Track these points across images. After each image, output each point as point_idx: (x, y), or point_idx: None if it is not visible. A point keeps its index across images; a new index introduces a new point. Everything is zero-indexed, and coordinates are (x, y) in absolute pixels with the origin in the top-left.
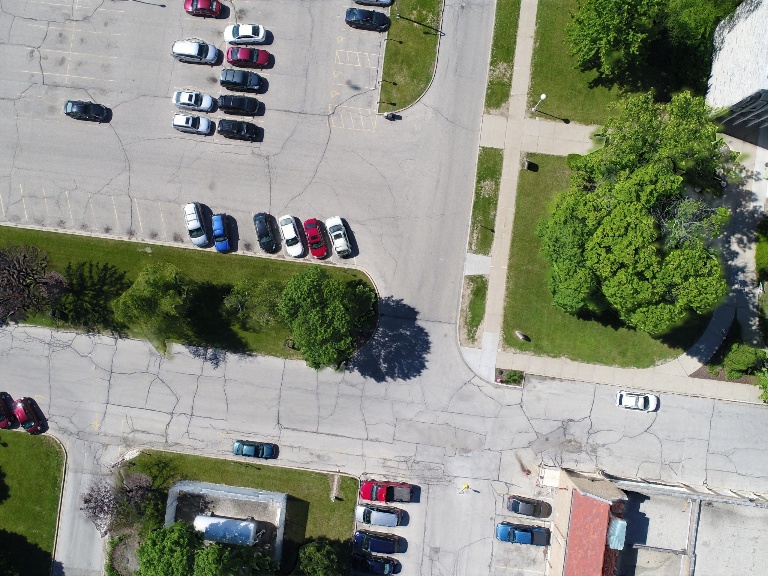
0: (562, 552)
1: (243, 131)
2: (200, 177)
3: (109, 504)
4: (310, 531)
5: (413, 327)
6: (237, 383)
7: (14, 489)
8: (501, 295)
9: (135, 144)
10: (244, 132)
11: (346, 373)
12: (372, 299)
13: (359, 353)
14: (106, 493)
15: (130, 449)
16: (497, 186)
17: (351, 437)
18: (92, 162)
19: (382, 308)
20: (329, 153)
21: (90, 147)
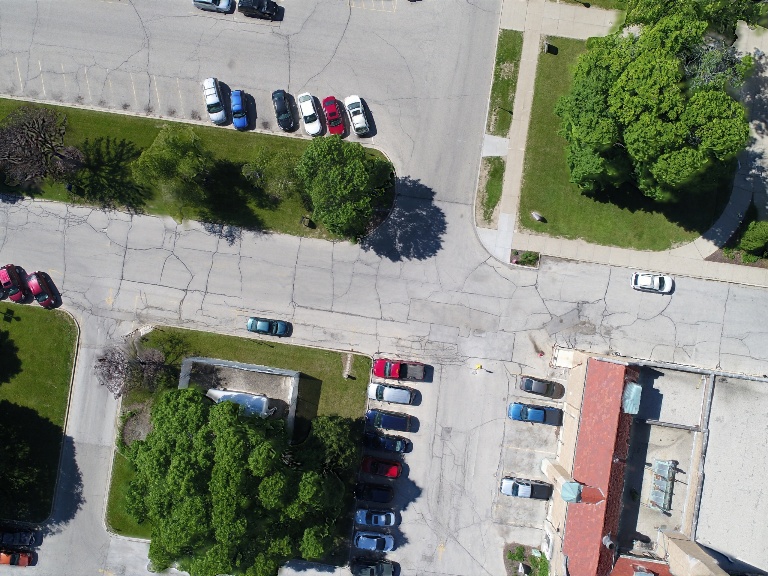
0: (575, 423)
1: (264, 8)
2: (219, 55)
3: (123, 365)
4: (322, 409)
5: (429, 207)
6: (252, 260)
7: (26, 363)
8: (518, 177)
9: (155, 21)
10: (264, 9)
11: (361, 252)
12: (391, 167)
13: (375, 232)
14: (120, 357)
15: (143, 325)
16: (516, 68)
17: (365, 316)
18: (111, 38)
19: (399, 188)
20: (349, 33)
21: (110, 24)
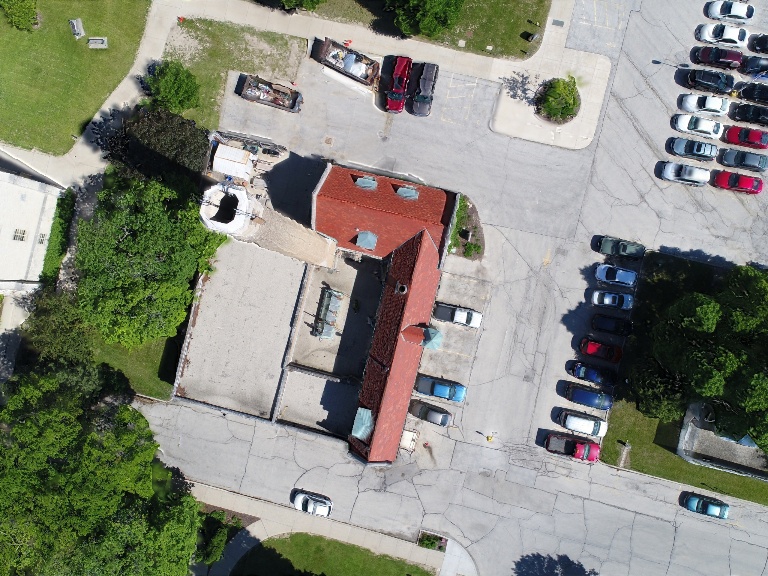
0: None
1: None
2: None
3: None
4: None
5: None
6: None
7: None
8: None
9: None
10: None
11: (598, 570)
12: None
13: None
14: None
15: None
16: None
17: (601, 503)
18: None
19: None
20: None
21: None
